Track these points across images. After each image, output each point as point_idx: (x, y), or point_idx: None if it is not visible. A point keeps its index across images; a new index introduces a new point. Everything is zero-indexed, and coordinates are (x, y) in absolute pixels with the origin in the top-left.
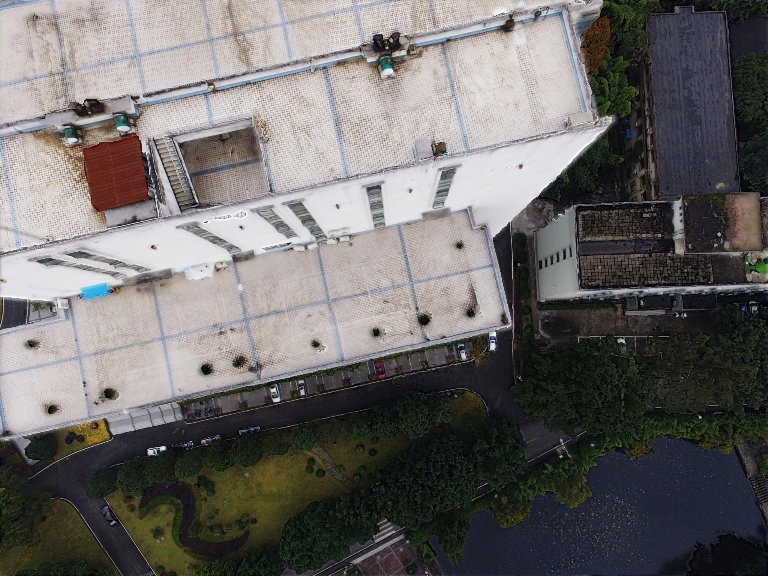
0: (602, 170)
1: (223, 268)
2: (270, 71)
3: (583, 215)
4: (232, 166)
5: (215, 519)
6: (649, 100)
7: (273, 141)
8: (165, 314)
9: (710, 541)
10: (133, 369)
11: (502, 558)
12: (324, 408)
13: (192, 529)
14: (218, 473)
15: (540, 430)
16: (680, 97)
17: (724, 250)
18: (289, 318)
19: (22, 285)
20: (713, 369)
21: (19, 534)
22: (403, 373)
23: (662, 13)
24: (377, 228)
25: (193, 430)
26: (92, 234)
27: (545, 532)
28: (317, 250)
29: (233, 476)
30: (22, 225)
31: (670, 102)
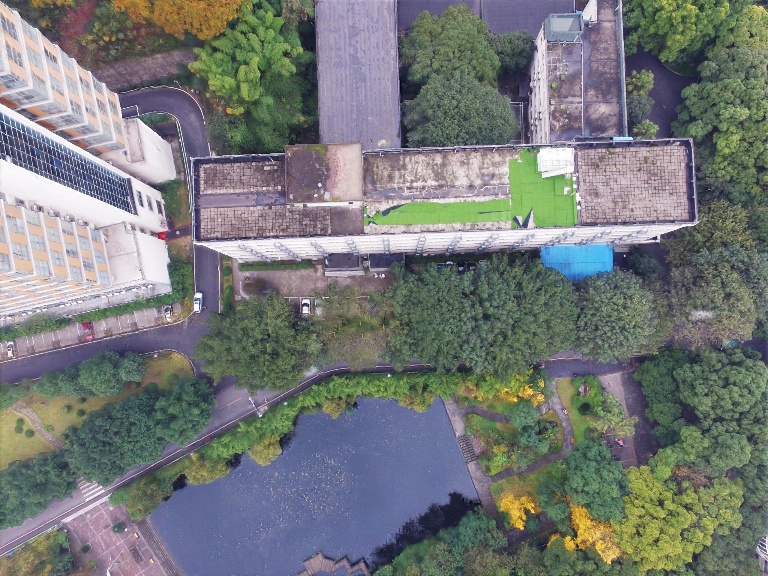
0: (301, 131)
1: None
2: None
3: (205, 168)
4: None
5: None
6: None
7: None
8: None
9: (439, 502)
10: None
11: (213, 517)
12: (34, 369)
13: None
14: None
15: (245, 390)
16: (346, 55)
17: (324, 200)
18: None
19: None
20: (362, 324)
21: None
22: (112, 335)
23: None
24: None
25: None
26: None
27: (255, 491)
28: None
29: None
30: None
31: (336, 60)
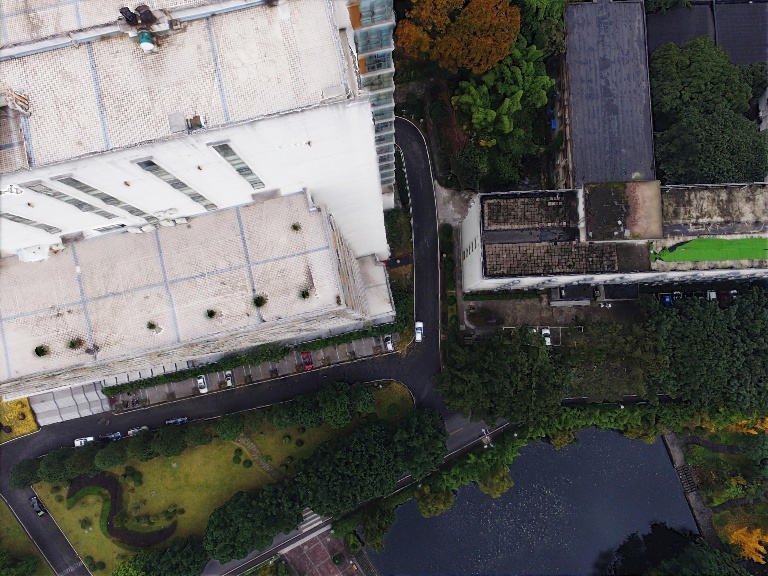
0: (527, 161)
1: (61, 250)
2: (30, 45)
3: (489, 204)
4: (21, 143)
5: (141, 509)
6: (567, 90)
7: (36, 116)
8: (3, 296)
9: (642, 531)
10: None
11: (430, 548)
12: (251, 399)
13: (116, 519)
14: (146, 464)
15: (466, 420)
16: (597, 87)
17: (624, 238)
18: (126, 300)
19: None
20: (625, 358)
21: None
22: (330, 364)
23: (580, 2)
24: (210, 210)
25: (121, 421)
26: None
27: (472, 522)
28: (155, 232)
29: (160, 467)
30: None
31: (587, 92)
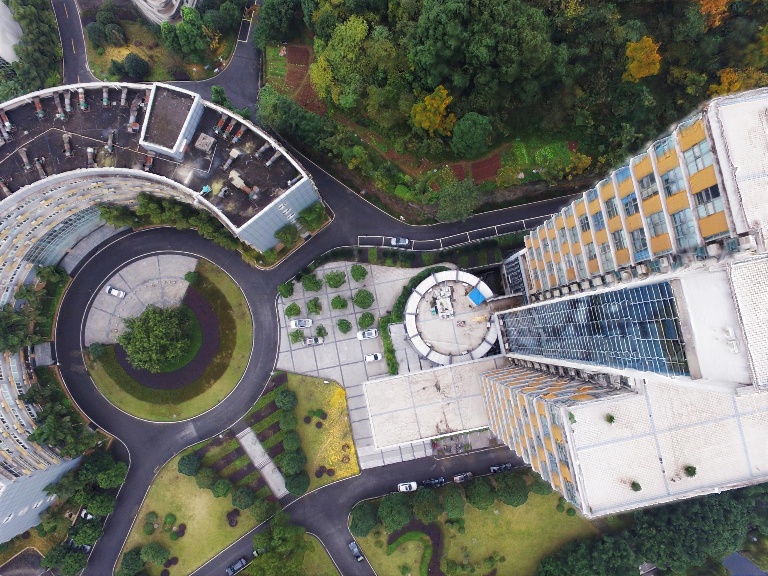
0: None
1: None
2: None
3: None
4: None
5: (471, 557)
6: None
7: None
8: None
9: None
10: (710, 446)
11: None
12: None
13: (452, 568)
14: (468, 510)
15: None
16: None
17: None
18: None
19: None
20: None
21: (292, 572)
22: None
23: None
24: None
25: (443, 466)
26: None
27: None
28: None
29: (483, 513)
30: None
31: None
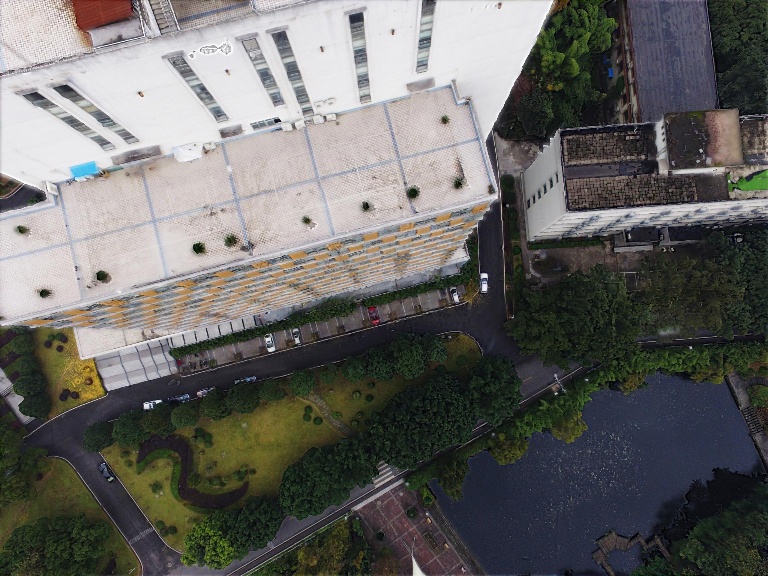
0: (586, 110)
1: (212, 150)
2: None
3: (568, 140)
4: (216, 12)
5: (214, 469)
6: (629, 34)
7: None
8: (155, 197)
9: (706, 478)
10: (125, 252)
11: (502, 499)
12: (319, 356)
13: (191, 479)
14: (215, 425)
15: (534, 369)
16: (659, 30)
17: (706, 166)
18: (279, 197)
19: (10, 148)
20: (701, 292)
21: (15, 488)
22: (397, 318)
23: None
24: (363, 102)
25: (189, 383)
26: (78, 56)
27: (543, 471)
28: (304, 130)
29: (230, 427)
30: (8, 54)
31: (649, 35)
